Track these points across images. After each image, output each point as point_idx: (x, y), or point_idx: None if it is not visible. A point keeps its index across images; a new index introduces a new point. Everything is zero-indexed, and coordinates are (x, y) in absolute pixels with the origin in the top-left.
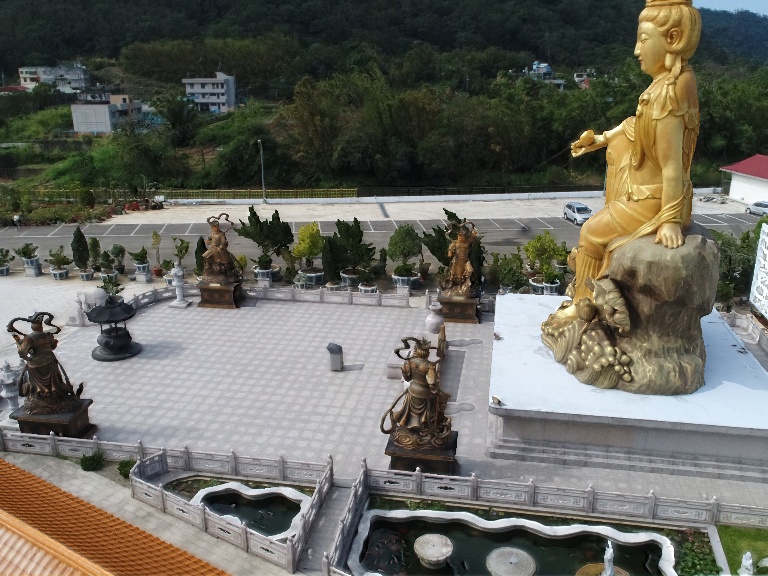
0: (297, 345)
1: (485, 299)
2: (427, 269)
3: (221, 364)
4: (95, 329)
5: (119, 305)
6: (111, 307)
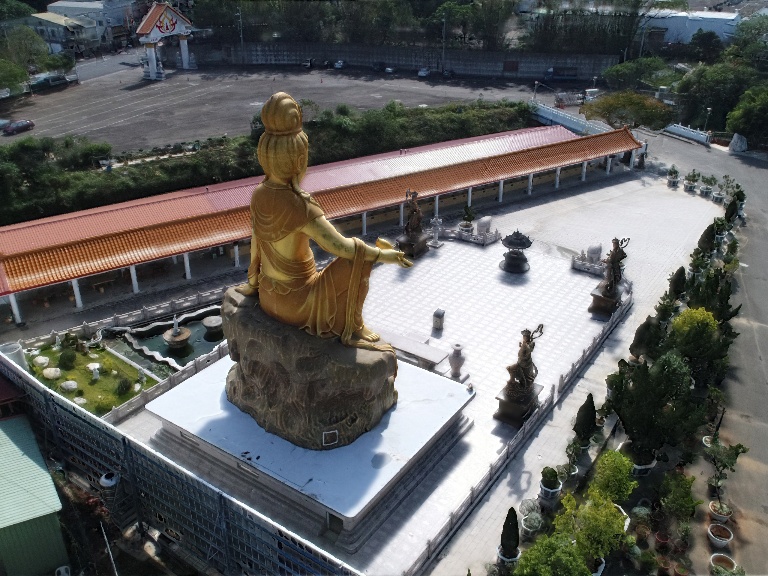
0: (492, 321)
1: (527, 421)
2: (690, 436)
3: (474, 293)
4: (567, 264)
5: (515, 238)
6: (512, 236)
